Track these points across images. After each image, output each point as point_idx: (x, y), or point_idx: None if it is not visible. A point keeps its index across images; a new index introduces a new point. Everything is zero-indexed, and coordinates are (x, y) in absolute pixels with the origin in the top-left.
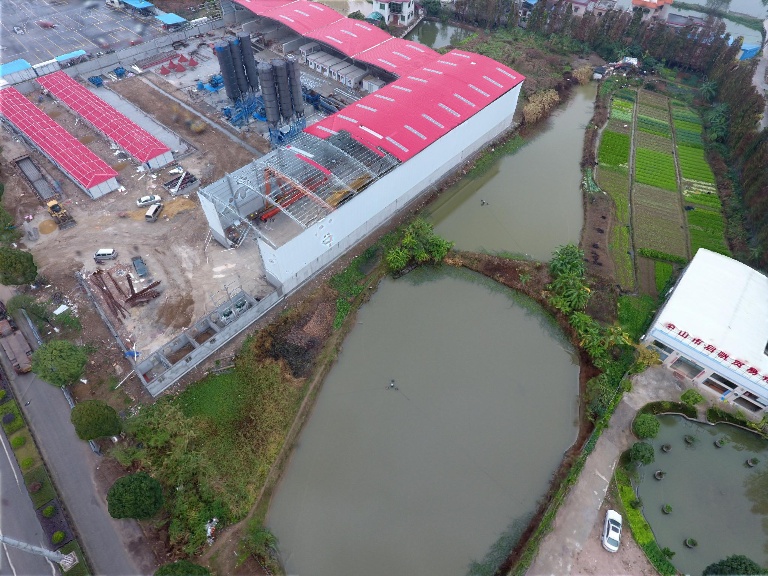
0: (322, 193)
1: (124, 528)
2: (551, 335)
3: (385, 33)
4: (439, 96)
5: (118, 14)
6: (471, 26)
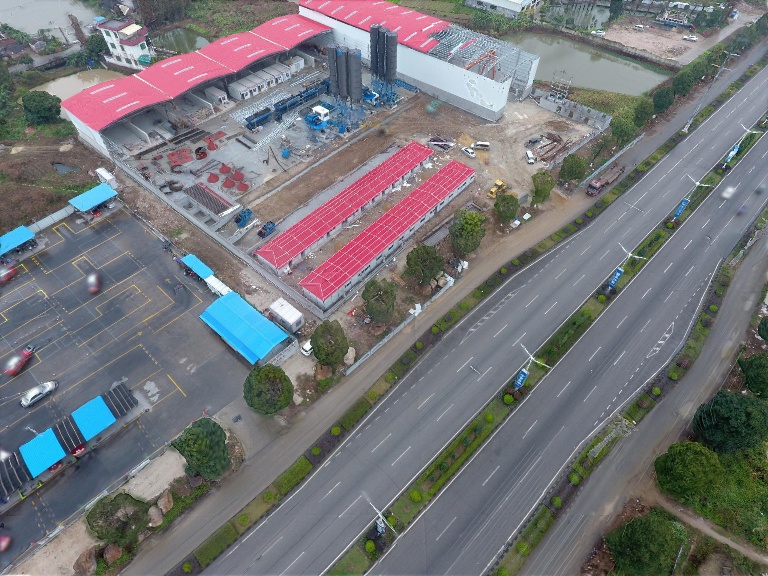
0: (494, 42)
1: (664, 124)
2: (518, 36)
3: (244, 33)
4: (378, 8)
5: (8, 280)
6: (167, 26)
